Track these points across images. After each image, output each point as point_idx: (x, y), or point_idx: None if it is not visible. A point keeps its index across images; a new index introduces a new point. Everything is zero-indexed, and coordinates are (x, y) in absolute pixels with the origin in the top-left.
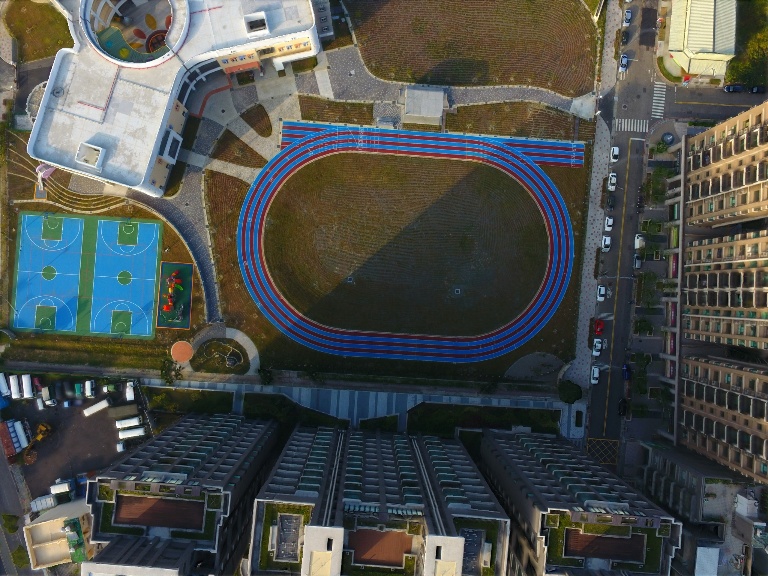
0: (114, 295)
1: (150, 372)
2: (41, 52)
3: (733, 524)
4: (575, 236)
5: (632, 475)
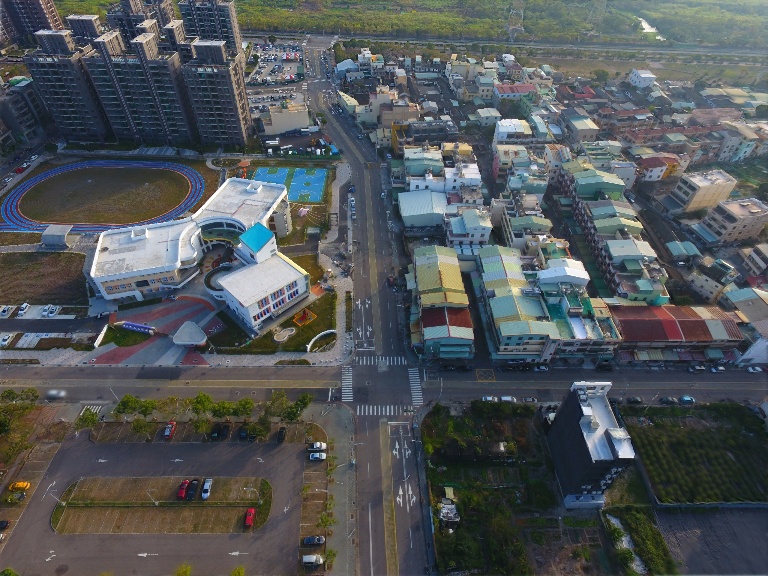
0: (275, 178)
1: (262, 159)
2: (302, 259)
3: (3, 94)
4: (6, 197)
5: (41, 135)
